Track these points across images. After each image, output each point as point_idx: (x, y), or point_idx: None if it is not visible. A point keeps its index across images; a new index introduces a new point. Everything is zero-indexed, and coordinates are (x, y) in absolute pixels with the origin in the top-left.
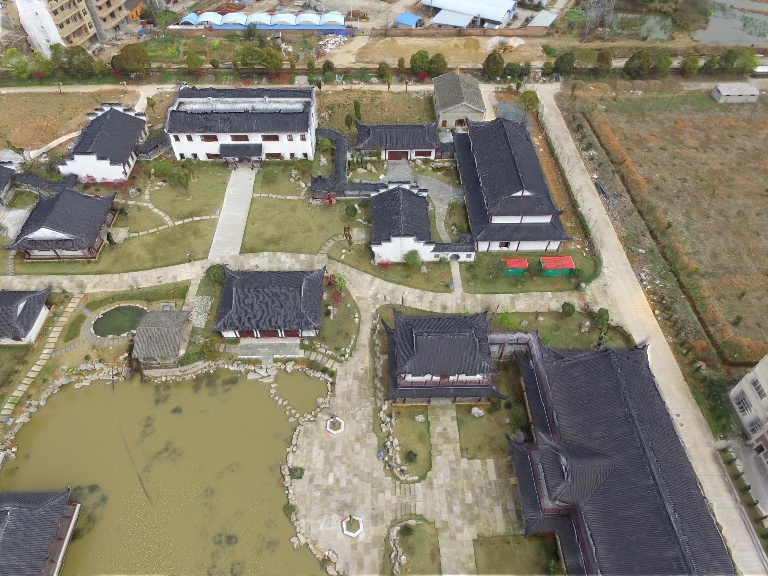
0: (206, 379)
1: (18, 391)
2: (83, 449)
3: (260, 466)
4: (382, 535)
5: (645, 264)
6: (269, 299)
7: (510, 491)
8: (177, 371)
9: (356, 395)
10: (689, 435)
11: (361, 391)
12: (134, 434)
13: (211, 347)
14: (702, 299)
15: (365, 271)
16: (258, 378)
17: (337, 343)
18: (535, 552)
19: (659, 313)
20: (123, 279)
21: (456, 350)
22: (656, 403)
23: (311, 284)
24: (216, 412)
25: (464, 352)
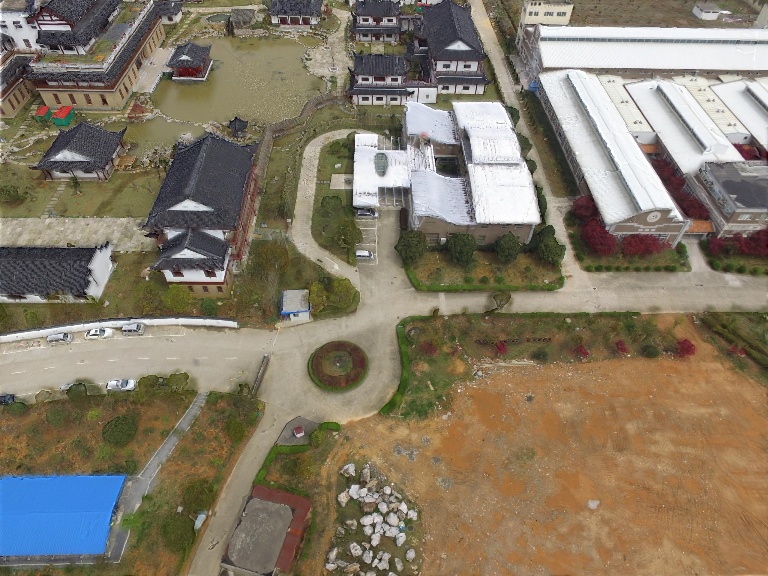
0: (264, 38)
1: (175, 36)
2: (209, 54)
3: (292, 58)
4: (346, 72)
5: (493, 10)
6: (295, 2)
7: (405, 62)
8: (250, 32)
9: (337, 42)
10: (493, 54)
11: (340, 41)
12: (232, 50)
13: (267, 20)
14: (517, 20)
15: (344, 10)
16: (290, 38)
17: (329, 28)
18: (412, 74)
19: (494, 24)
20: (217, 9)
21: (383, 7)
22: (469, 20)
23: (316, 3)
24: (270, 46)
25: (386, 8)
